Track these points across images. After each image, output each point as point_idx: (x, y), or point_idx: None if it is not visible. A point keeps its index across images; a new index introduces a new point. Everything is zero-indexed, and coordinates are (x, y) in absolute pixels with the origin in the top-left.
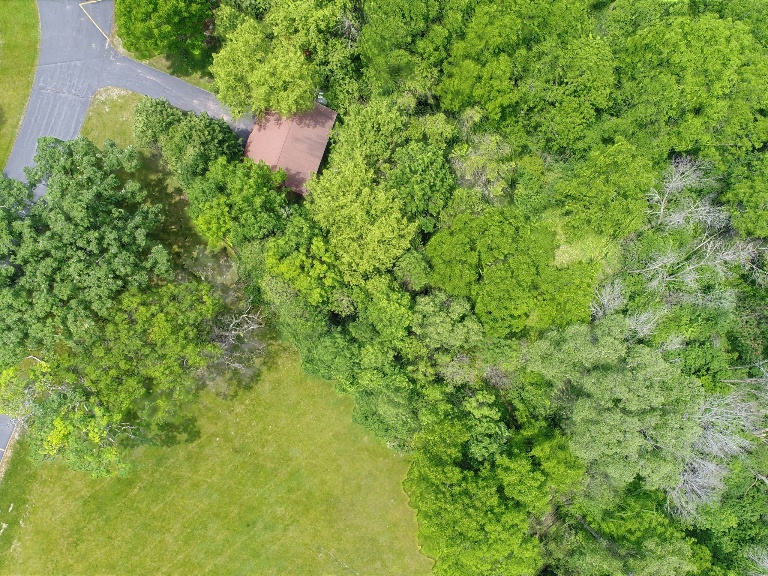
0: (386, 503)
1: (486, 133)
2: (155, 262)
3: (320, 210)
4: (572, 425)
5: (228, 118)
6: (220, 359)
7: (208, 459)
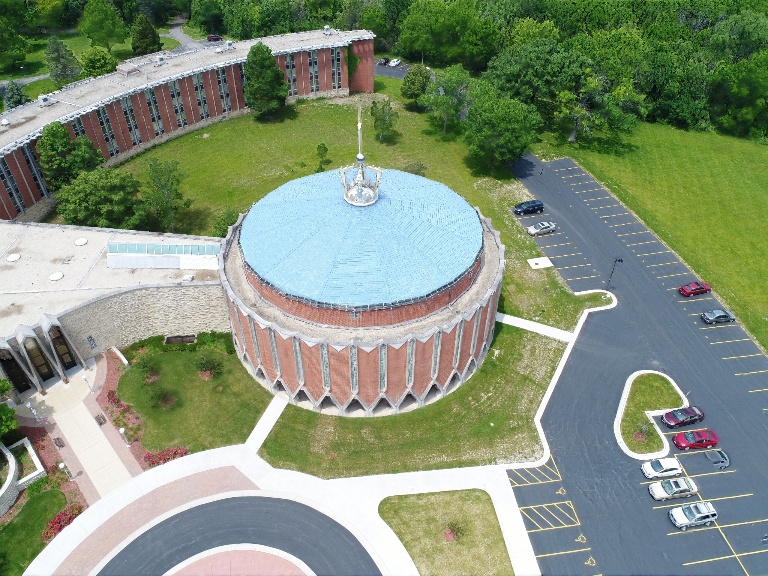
0: (728, 144)
1: (621, 25)
2: None
3: None
4: (754, 33)
5: None
6: None
7: (652, 151)
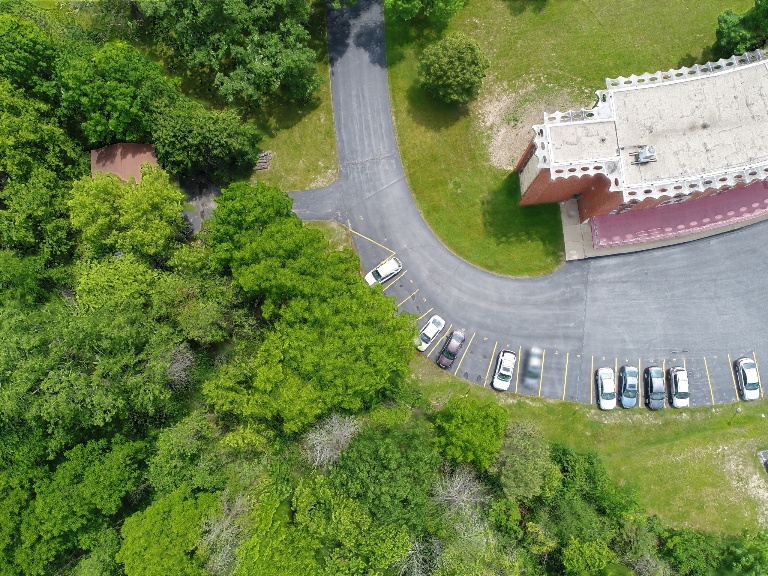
0: None
1: None
2: (152, 1)
3: (7, 88)
4: None
5: (210, 206)
6: (139, 4)
7: None
